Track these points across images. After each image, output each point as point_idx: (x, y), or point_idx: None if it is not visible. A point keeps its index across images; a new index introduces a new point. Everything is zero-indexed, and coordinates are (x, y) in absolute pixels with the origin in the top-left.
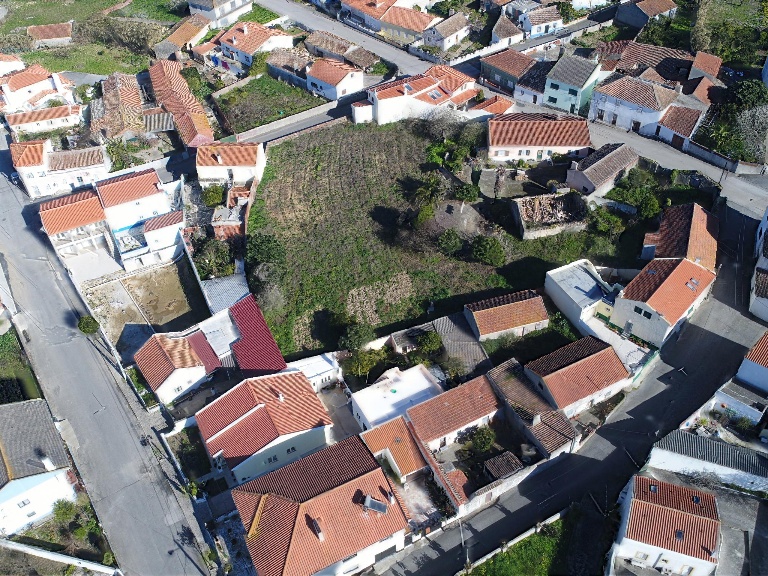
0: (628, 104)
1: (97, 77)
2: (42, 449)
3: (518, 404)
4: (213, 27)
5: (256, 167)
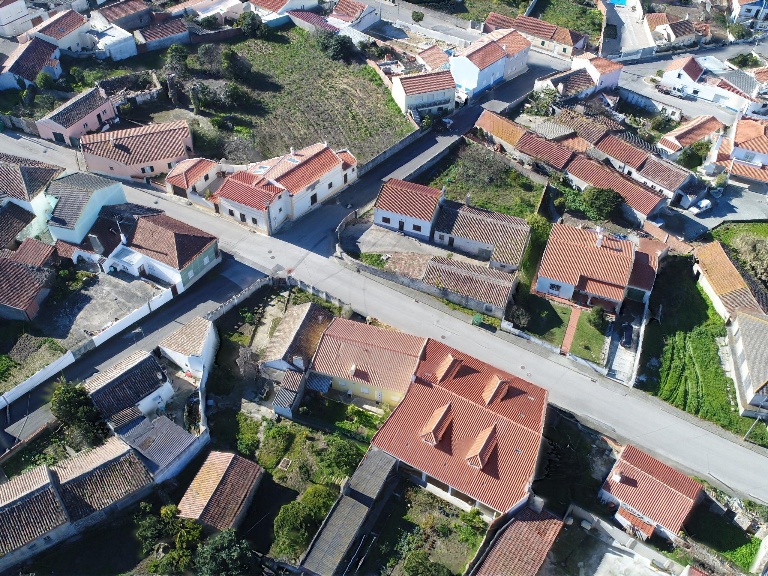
0: None
1: (749, 215)
2: None
3: (153, 4)
4: None
5: None
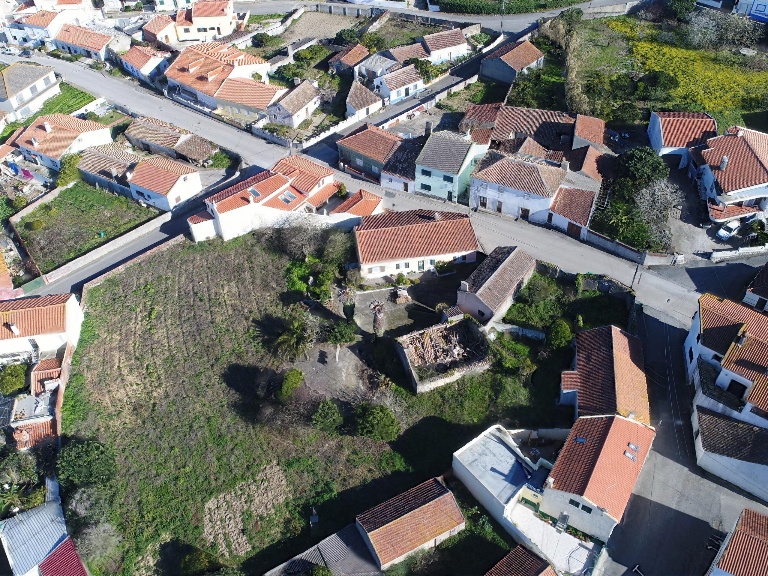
0: (513, 191)
1: None
2: None
3: None
4: (11, 120)
5: (66, 332)
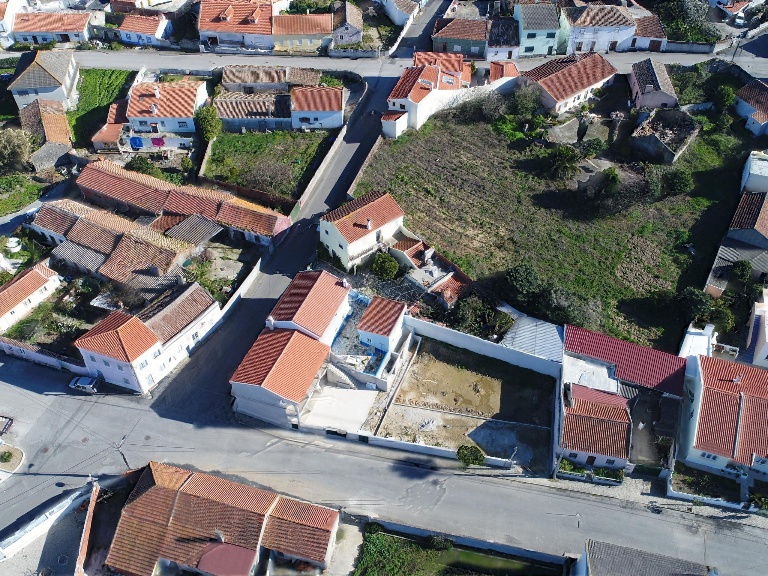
0: (606, 29)
1: None
2: (674, 573)
3: None
4: (64, 110)
5: None
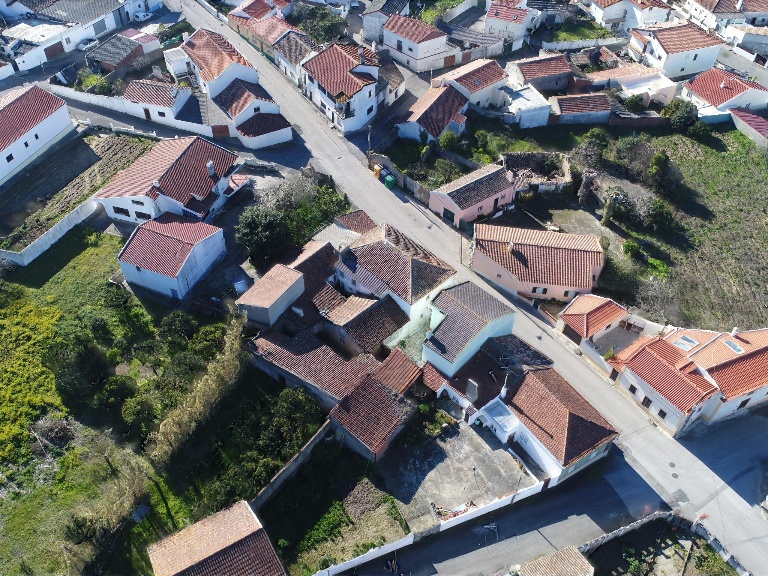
0: None
1: None
2: None
3: (574, 66)
4: None
5: None
